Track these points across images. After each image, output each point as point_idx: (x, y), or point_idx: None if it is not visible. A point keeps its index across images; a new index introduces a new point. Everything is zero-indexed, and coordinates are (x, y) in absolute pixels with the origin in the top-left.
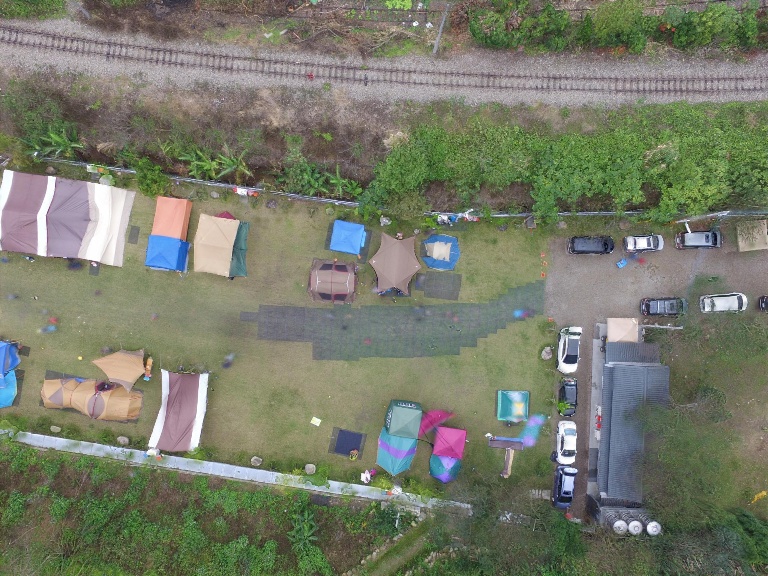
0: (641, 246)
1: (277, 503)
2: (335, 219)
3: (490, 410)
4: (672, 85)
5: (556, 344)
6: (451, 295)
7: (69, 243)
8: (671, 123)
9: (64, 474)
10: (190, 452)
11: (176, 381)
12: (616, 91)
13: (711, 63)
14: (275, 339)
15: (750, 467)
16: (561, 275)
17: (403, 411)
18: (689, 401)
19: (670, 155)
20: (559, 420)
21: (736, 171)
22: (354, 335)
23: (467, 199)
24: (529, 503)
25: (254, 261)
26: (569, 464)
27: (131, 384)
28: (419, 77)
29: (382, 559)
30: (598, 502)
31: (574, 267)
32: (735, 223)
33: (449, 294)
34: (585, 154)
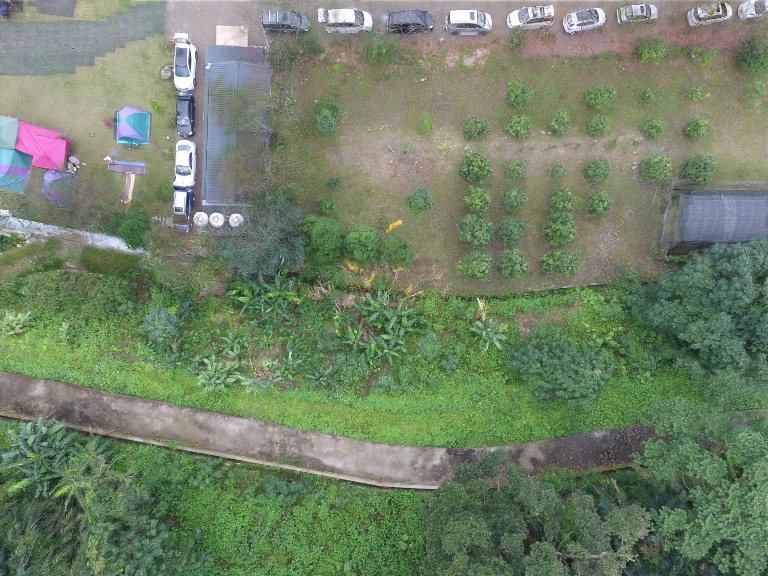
0: None
1: None
2: None
3: (109, 132)
4: None
5: None
6: (66, 11)
7: None
8: None
9: None
10: None
11: None
12: None
13: None
14: None
15: (384, 195)
16: None
17: None
18: None
19: None
20: None
21: None
22: None
23: None
24: None
25: None
26: (189, 186)
27: None
28: None
29: None
30: None
31: None
32: None
33: (64, 10)
34: None
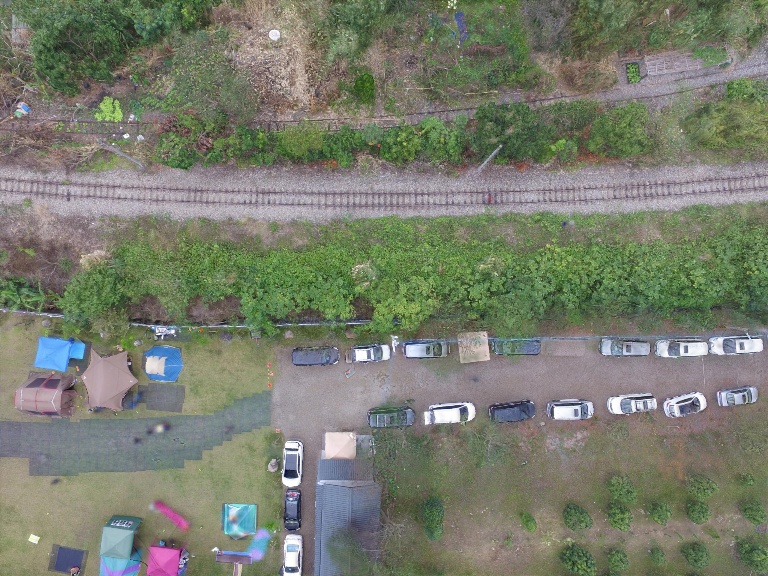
0: (361, 359)
1: None
2: (52, 331)
3: (217, 524)
4: (382, 199)
5: None
6: (175, 407)
7: None
8: (382, 238)
9: None
10: None
11: None
12: (325, 206)
13: (423, 177)
14: None
15: None
16: (289, 385)
17: (113, 532)
18: (421, 511)
19: (370, 274)
20: (287, 533)
21: (447, 286)
22: (73, 449)
23: (184, 311)
24: None
25: None
26: None
27: None
28: (124, 192)
29: None
30: None
31: (302, 377)
32: None
33: (172, 406)
34: (293, 270)
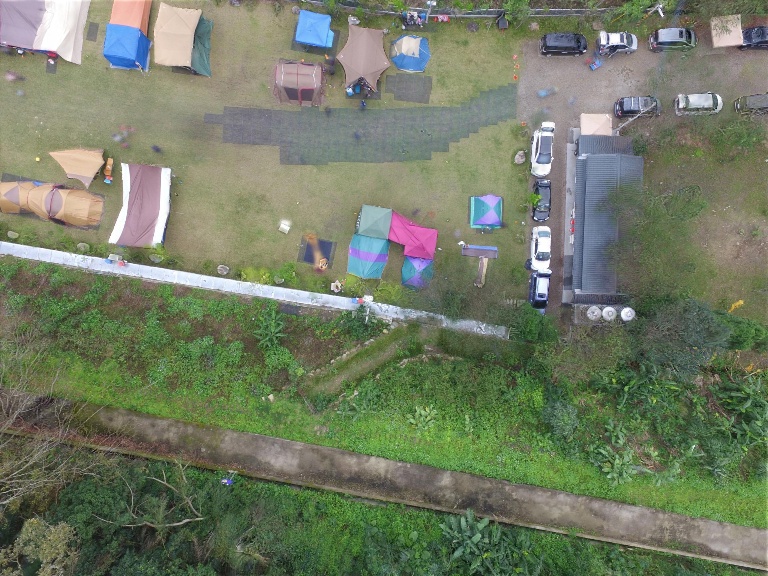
0: (614, 42)
1: (244, 311)
2: None
3: (463, 217)
4: None
5: (529, 149)
6: (422, 98)
7: (23, 32)
8: None
9: (21, 276)
10: (154, 259)
11: (137, 174)
12: None
13: None
14: (241, 142)
15: (727, 275)
16: (534, 78)
17: (373, 209)
18: None
19: None
20: (533, 227)
21: None
22: (322, 139)
23: None
24: (504, 313)
25: (218, 61)
26: None
27: (90, 179)
28: None
29: (352, 360)
30: (573, 303)
31: (547, 70)
32: (709, 20)
33: (420, 97)
34: None
